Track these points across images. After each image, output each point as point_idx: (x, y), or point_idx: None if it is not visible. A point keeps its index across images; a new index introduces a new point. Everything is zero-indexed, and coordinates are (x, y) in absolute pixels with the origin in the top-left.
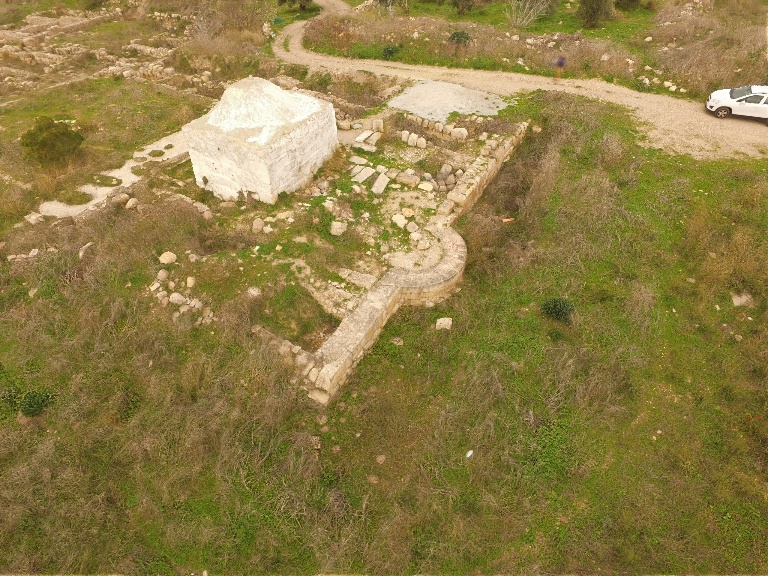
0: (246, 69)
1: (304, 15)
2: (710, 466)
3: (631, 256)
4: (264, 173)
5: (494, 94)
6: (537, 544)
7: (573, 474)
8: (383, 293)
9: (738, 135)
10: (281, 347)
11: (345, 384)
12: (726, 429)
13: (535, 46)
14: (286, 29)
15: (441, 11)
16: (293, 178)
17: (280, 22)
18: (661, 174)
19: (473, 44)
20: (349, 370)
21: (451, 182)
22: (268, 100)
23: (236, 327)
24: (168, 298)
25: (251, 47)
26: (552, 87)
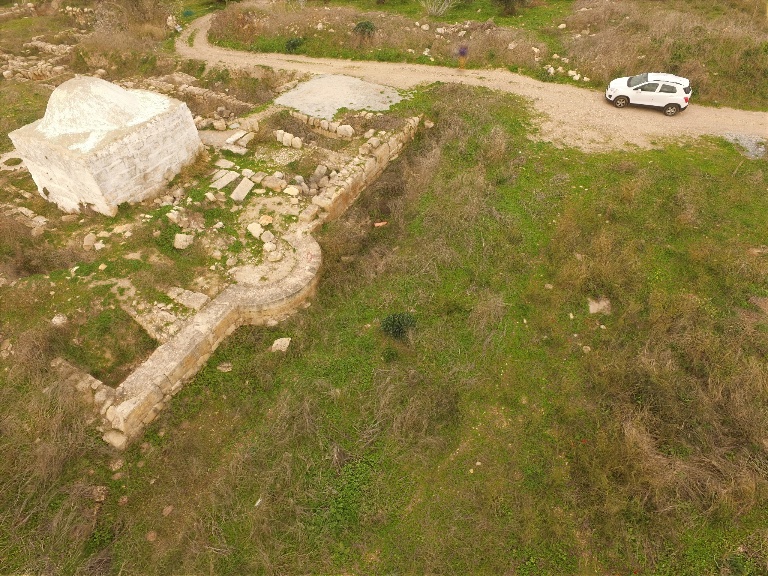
0: (143, 66)
1: (218, 7)
2: (522, 502)
3: (492, 261)
4: (93, 183)
5: (392, 87)
6: None
7: (366, 521)
8: (213, 314)
9: (634, 125)
10: (79, 383)
11: (154, 421)
12: (551, 456)
13: (446, 36)
14: (195, 22)
15: (363, 1)
16: (137, 187)
17: (190, 15)
18: (543, 170)
19: (378, 35)
20: (159, 405)
21: (324, 185)
22: (97, 102)
23: (26, 363)
24: None
25: (149, 42)
26: (454, 79)
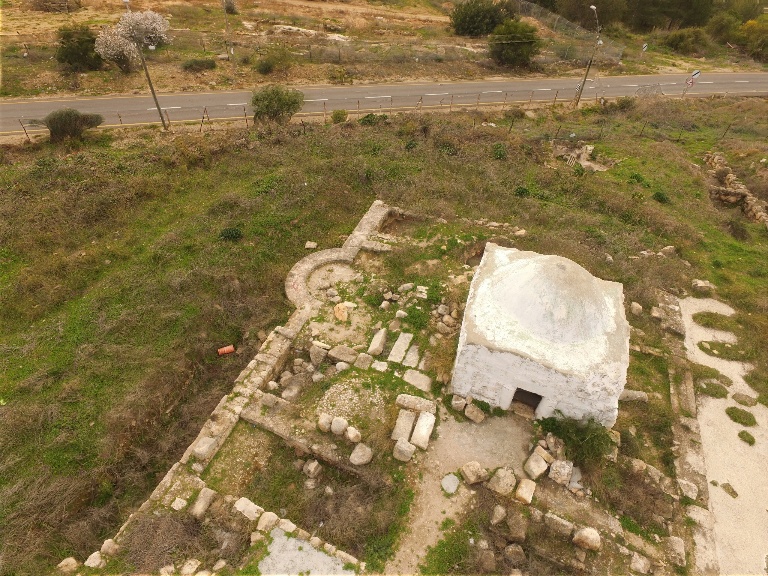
0: None
1: None
2: None
3: None
4: None
5: None
6: (283, 169)
7: None
8: (355, 241)
9: None
10: (411, 210)
11: None
12: None
13: None
14: None
15: None
16: None
17: None
18: None
19: None
20: None
21: None
22: None
23: None
24: (500, 225)
25: None
26: None
